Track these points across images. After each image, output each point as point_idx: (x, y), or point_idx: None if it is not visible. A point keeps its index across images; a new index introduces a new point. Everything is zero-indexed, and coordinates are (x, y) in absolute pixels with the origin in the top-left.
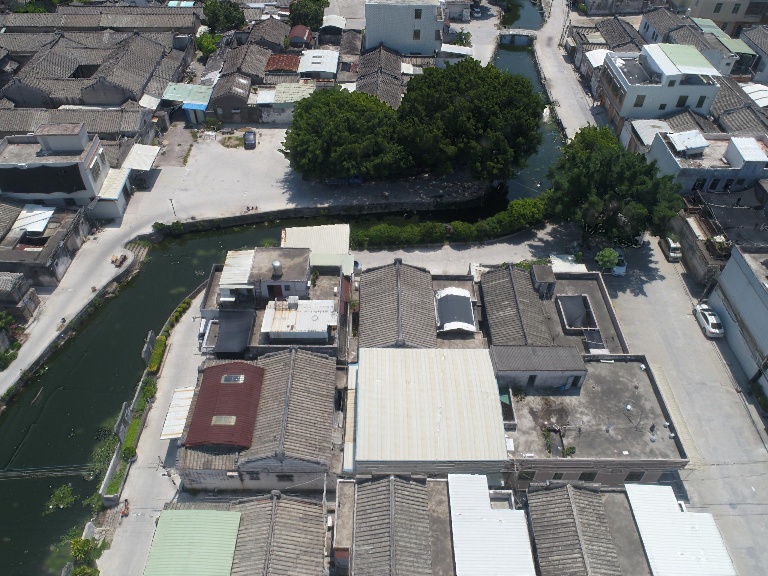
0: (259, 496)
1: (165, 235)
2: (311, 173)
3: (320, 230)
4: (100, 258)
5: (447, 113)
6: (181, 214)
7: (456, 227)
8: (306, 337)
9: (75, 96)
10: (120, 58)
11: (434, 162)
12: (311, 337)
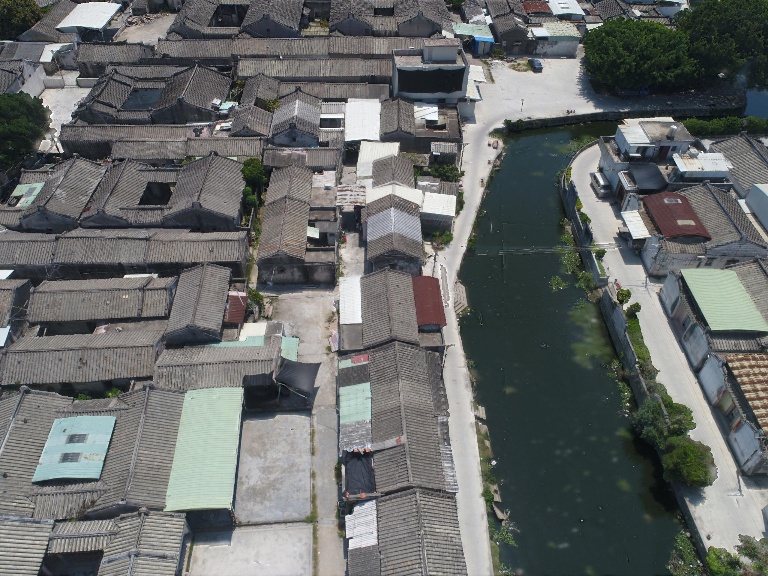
0: (742, 262)
1: (509, 131)
2: (620, 83)
3: (652, 120)
4: (477, 143)
5: (742, 31)
6: (518, 115)
7: (753, 120)
8: (711, 177)
9: (393, 29)
10: (418, 0)
11: (701, 80)
12: (714, 177)
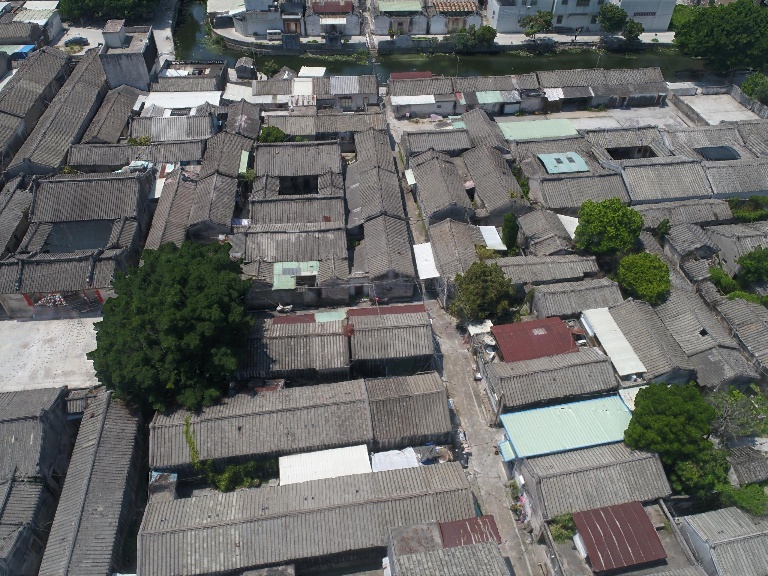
0: None
1: None
2: (156, 5)
3: (212, 5)
4: None
5: None
6: (165, 56)
7: None
8: None
9: None
10: None
11: None
12: None
